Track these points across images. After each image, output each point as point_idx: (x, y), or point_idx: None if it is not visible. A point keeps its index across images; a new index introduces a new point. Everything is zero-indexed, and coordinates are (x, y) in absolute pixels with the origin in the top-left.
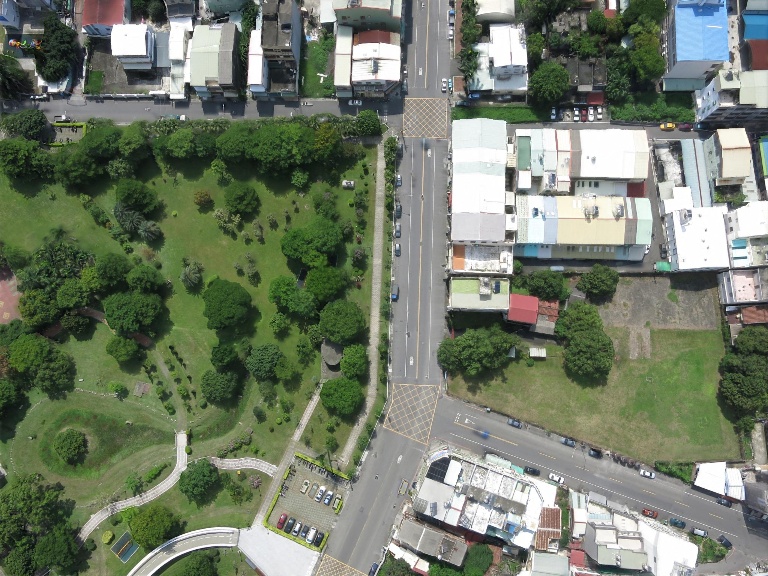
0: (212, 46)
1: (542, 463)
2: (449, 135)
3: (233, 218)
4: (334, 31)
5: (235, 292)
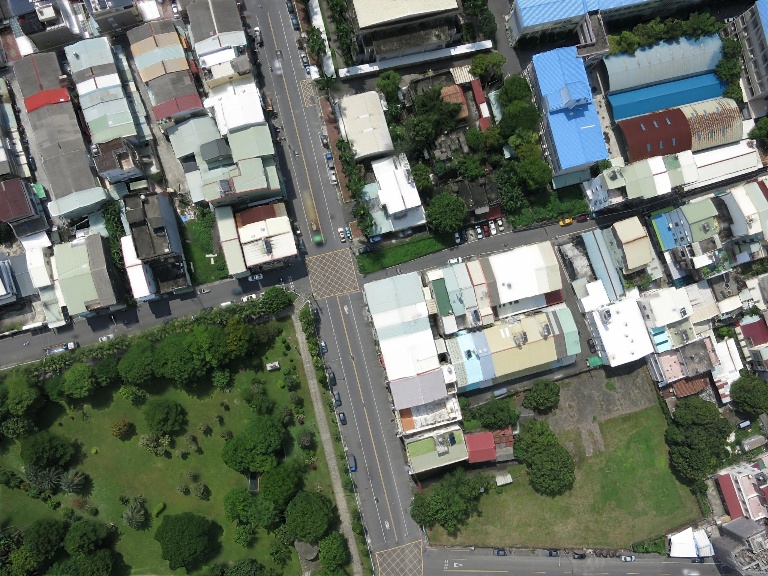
0: (81, 267)
1: None
2: (361, 286)
3: (162, 440)
4: (211, 208)
5: (190, 526)
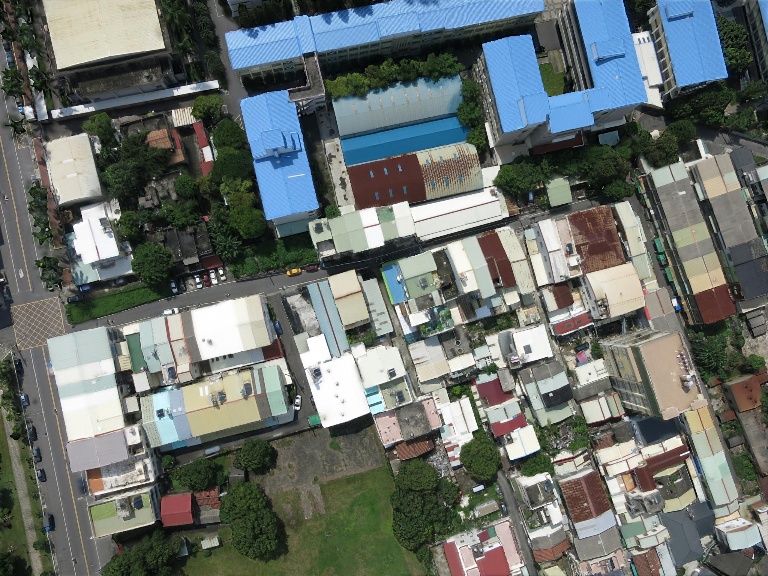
0: None
1: None
2: None
3: None
4: None
5: None
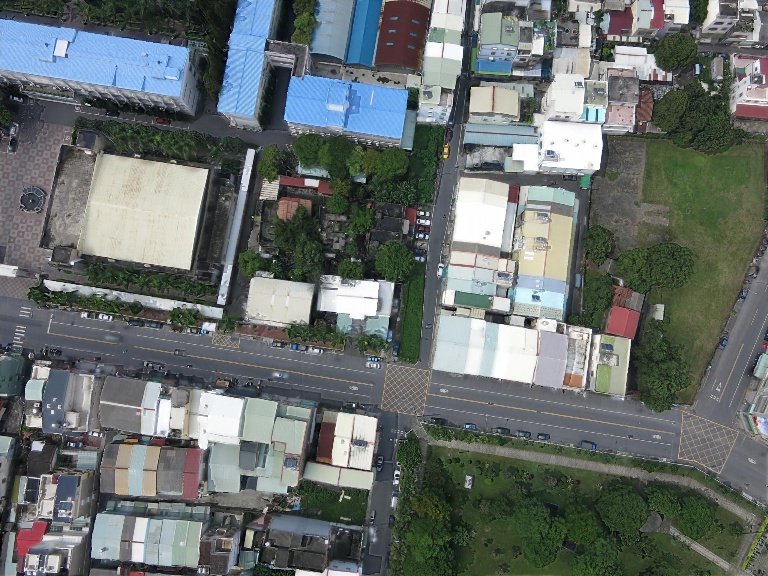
0: None
1: (761, 323)
2: (427, 367)
3: None
4: None
5: None
